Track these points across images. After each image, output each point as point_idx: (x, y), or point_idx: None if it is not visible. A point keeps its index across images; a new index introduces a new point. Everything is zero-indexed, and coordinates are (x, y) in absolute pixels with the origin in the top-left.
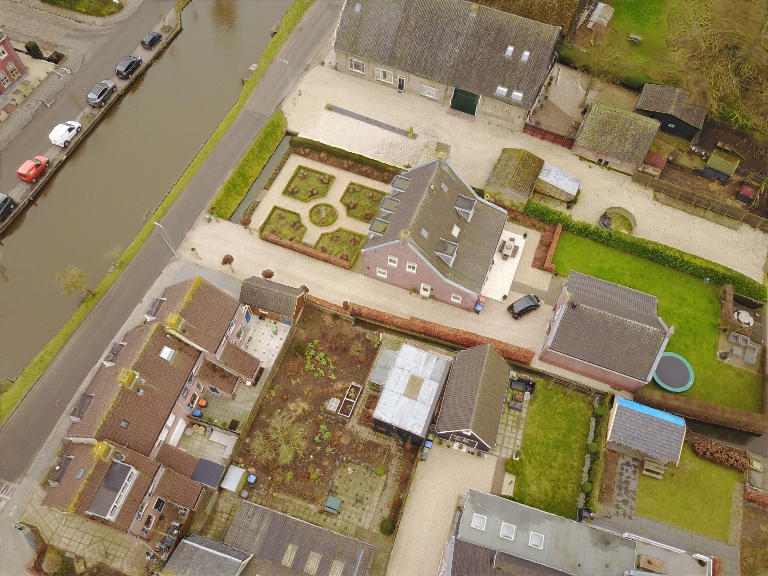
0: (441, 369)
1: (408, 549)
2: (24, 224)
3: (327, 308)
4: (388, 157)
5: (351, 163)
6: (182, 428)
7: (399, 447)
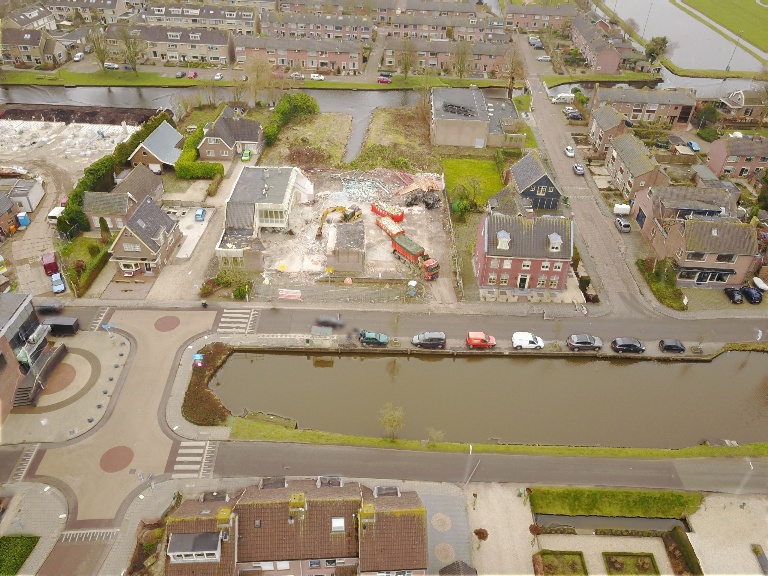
0: None
1: None
2: (436, 363)
3: None
4: None
5: None
6: None
7: None
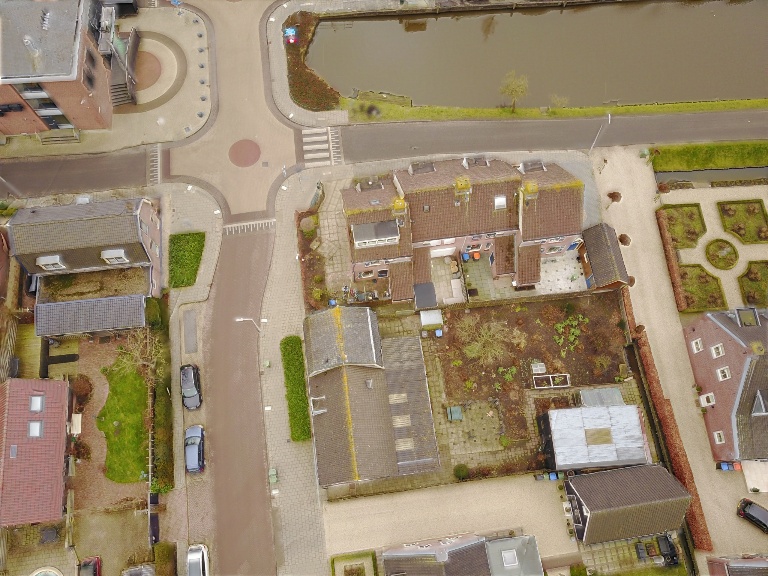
0: (633, 455)
1: (453, 499)
2: (539, 16)
3: (626, 313)
4: None
5: None
6: (448, 253)
7: (535, 449)
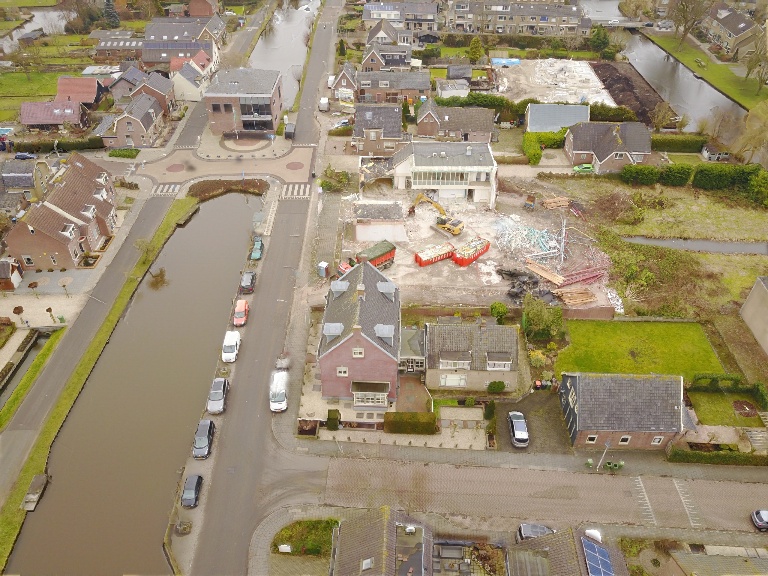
0: None
1: None
2: None
3: None
4: None
5: None
6: None
7: None
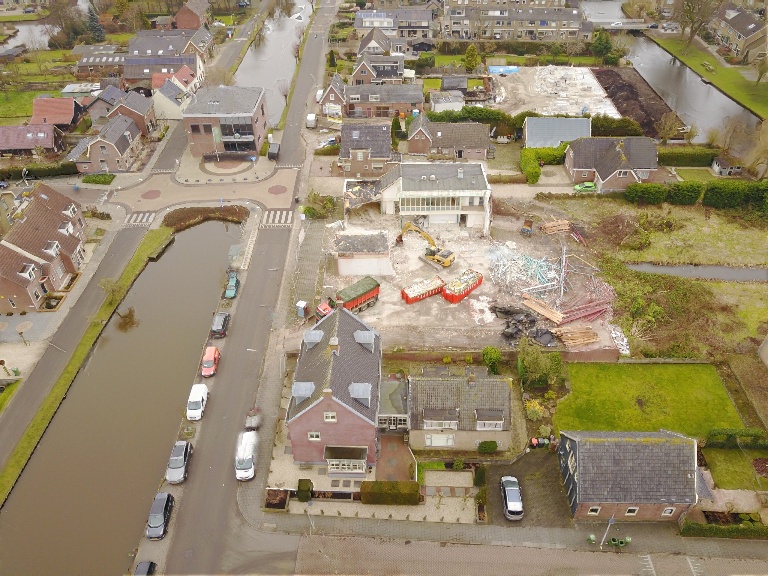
0: None
1: None
2: None
3: None
4: None
5: None
6: None
7: None
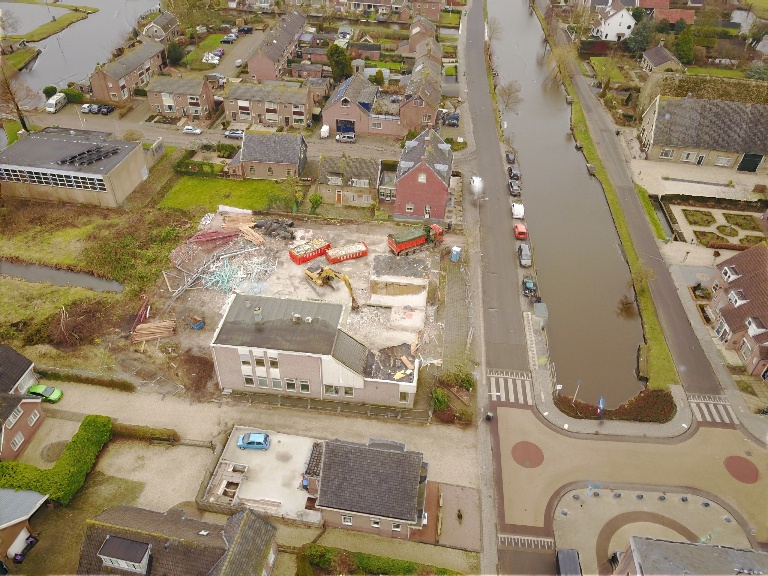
0: None
1: None
2: None
3: None
4: (729, 198)
5: (713, 204)
6: None
7: None
